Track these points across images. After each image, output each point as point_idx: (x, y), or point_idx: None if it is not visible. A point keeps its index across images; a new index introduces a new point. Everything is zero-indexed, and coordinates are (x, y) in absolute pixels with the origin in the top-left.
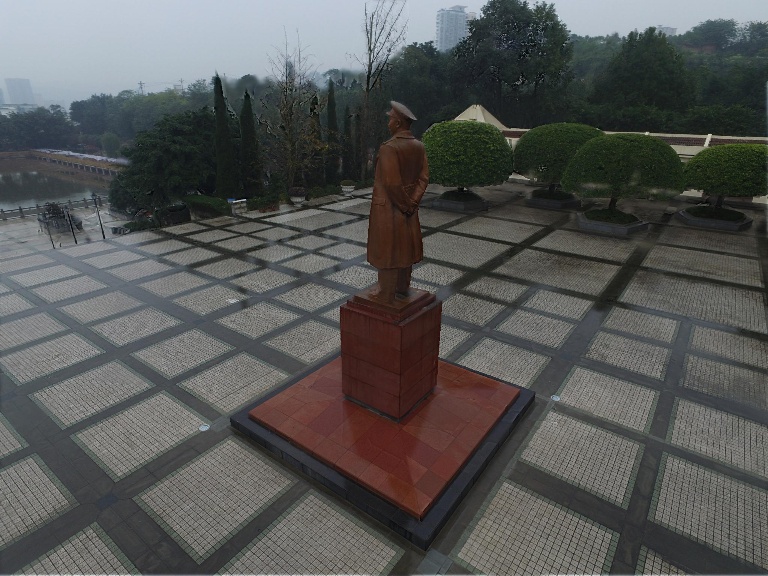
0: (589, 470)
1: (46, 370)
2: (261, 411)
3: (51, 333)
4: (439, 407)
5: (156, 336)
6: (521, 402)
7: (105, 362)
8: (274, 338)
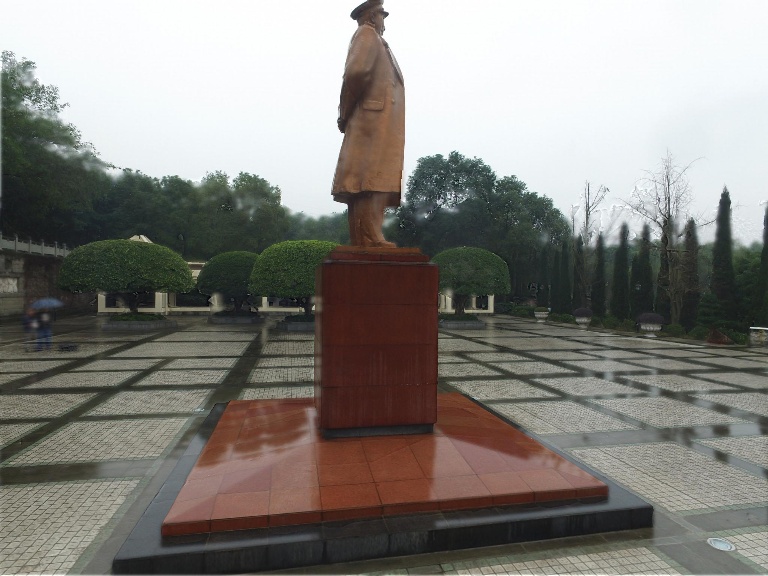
0: (4, 506)
1: (640, 380)
2: (450, 393)
3: (740, 384)
4: (292, 431)
5: (720, 406)
6: (154, 522)
7: (646, 390)
8: (692, 450)
